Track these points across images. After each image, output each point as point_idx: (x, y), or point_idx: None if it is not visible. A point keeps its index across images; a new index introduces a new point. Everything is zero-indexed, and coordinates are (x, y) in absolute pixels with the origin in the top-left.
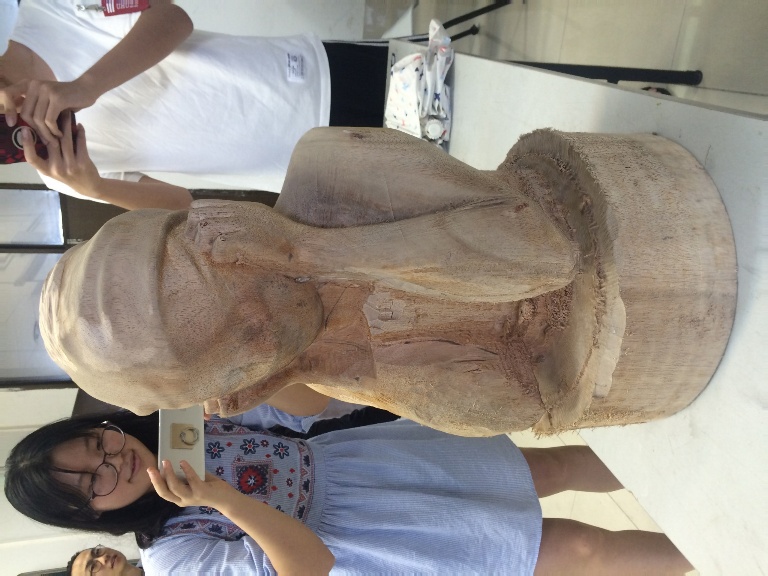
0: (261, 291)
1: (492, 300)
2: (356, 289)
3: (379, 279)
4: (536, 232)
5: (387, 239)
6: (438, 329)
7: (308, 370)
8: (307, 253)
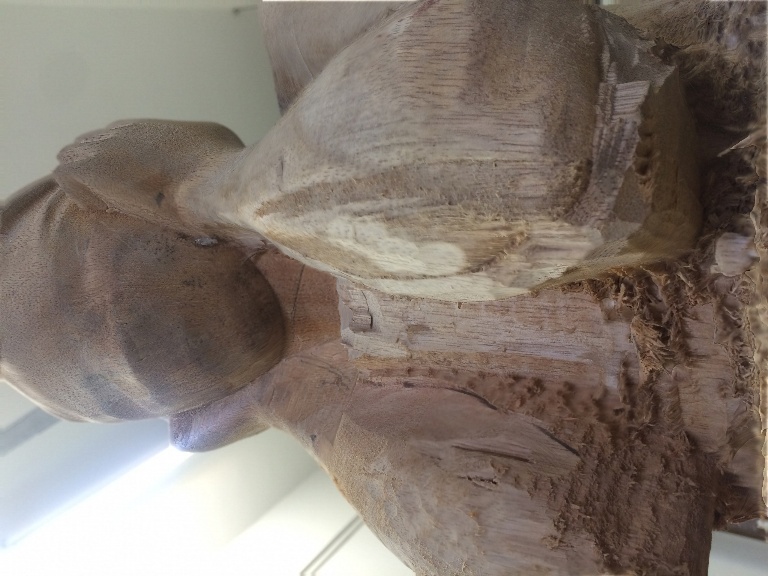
0: (121, 255)
1: (419, 291)
2: None
3: None
4: (447, 64)
5: (251, 150)
6: (464, 365)
7: (266, 404)
8: (185, 192)
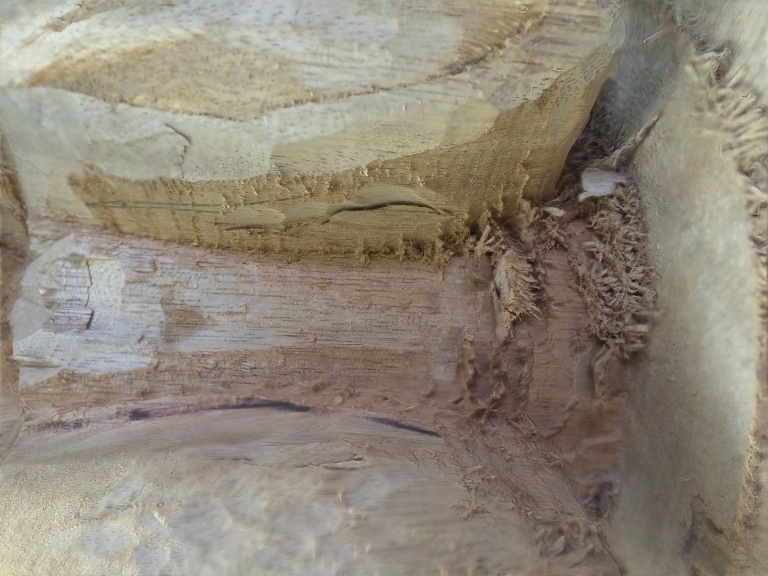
0: None
1: (342, 126)
2: None
3: None
4: None
5: None
6: (245, 372)
7: None
8: None
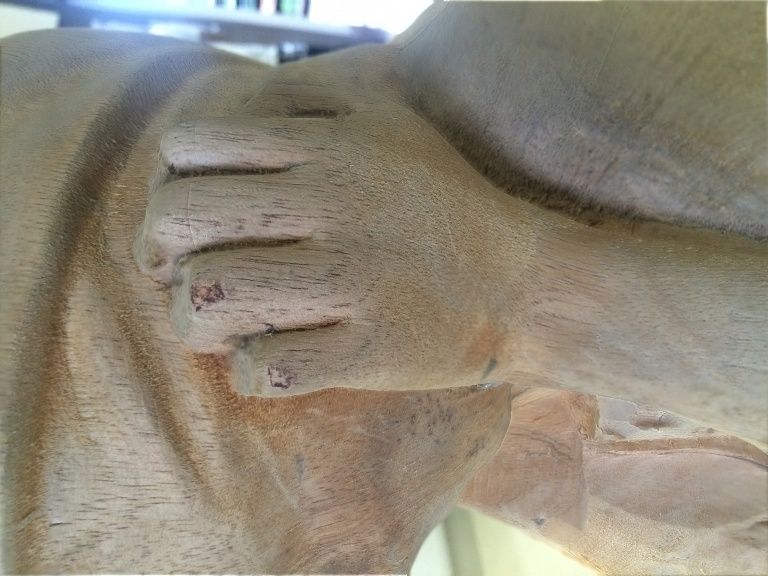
0: (380, 463)
1: None
2: None
3: None
4: None
5: None
6: None
7: None
8: (541, 352)
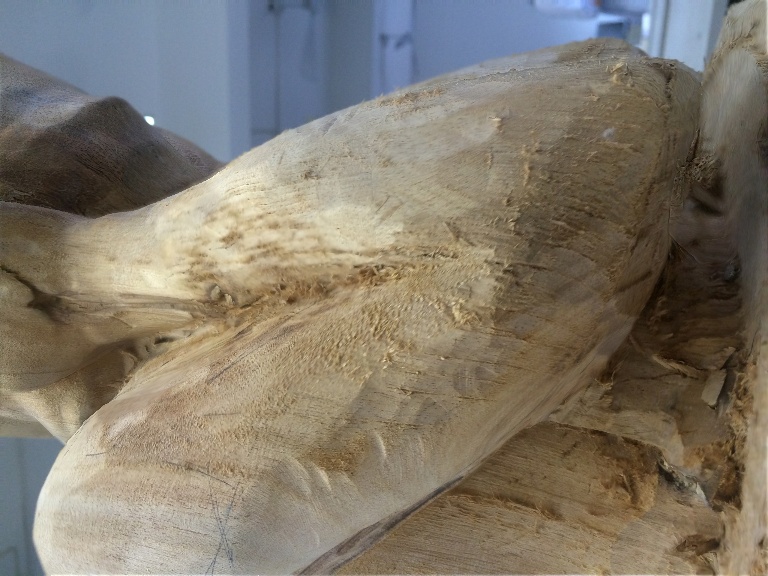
0: None
1: None
2: None
3: None
4: None
5: None
6: None
7: None
8: None
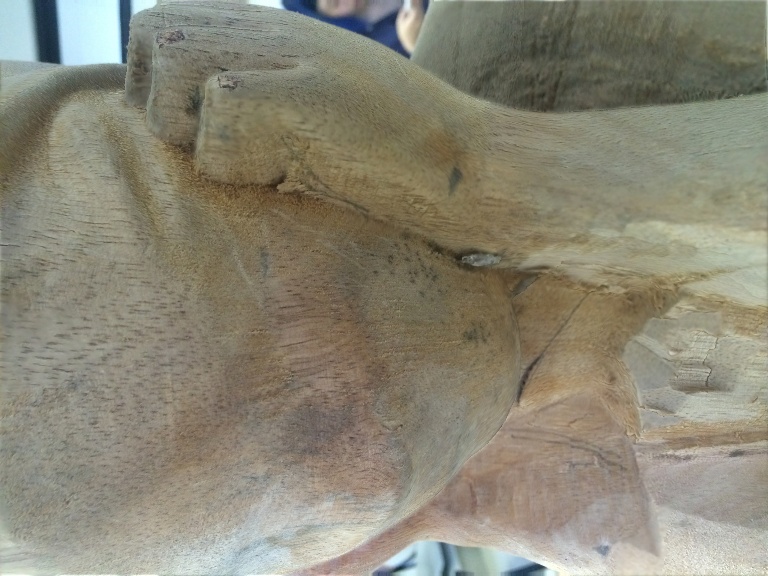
0: (354, 285)
1: None
2: (611, 299)
3: (725, 269)
4: None
5: None
6: None
7: (466, 513)
8: (507, 171)
